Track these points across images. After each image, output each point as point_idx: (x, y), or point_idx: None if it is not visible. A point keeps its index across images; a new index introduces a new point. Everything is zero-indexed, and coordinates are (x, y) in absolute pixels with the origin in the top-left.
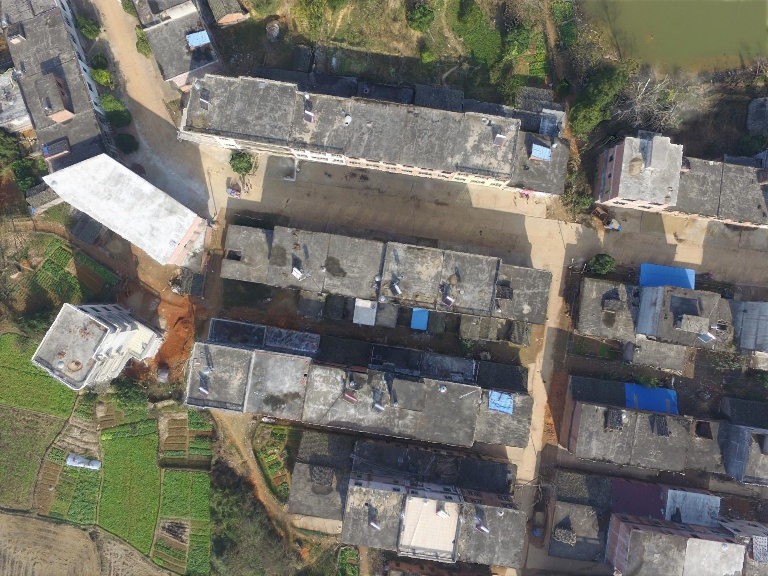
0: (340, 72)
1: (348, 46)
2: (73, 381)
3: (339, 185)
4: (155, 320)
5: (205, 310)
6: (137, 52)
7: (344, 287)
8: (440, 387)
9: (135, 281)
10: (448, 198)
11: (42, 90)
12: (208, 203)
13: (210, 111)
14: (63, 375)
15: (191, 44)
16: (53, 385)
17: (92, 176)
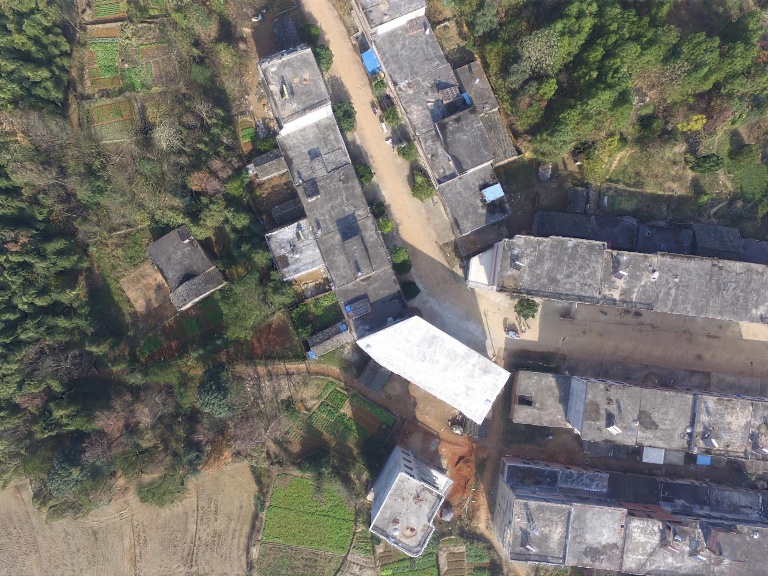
0: (611, 210)
1: (625, 187)
2: (408, 547)
3: (614, 322)
4: (437, 460)
5: (486, 449)
6: (408, 194)
7: (657, 439)
8: (753, 533)
9: (413, 422)
10: (719, 331)
11: (350, 253)
12: (486, 344)
13: (521, 271)
14: (398, 542)
15: (488, 198)
16: (330, 523)
17: (406, 339)
